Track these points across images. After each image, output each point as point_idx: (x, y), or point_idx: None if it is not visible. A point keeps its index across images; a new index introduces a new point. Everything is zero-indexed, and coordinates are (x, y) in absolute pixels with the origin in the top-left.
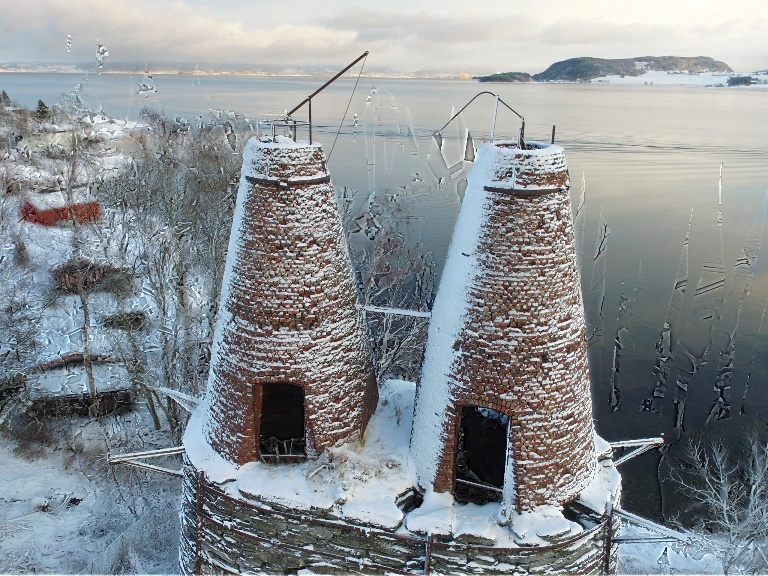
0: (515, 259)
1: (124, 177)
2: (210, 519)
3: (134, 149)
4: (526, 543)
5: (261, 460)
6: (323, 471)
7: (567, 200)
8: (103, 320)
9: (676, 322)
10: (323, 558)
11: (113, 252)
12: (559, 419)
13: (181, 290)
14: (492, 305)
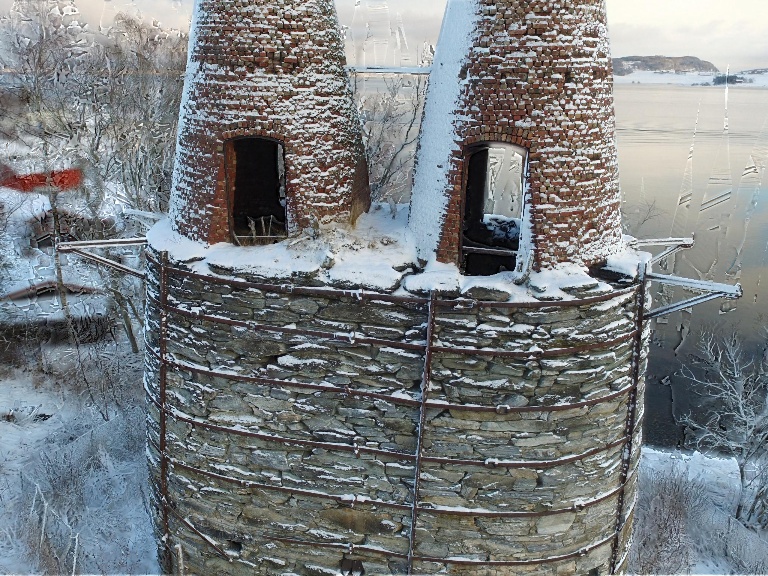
0: None
1: (95, 68)
2: (175, 309)
3: (107, 44)
4: (547, 296)
5: (235, 242)
6: (307, 240)
7: None
8: (72, 215)
9: None
10: (307, 338)
11: (84, 149)
12: (584, 156)
13: None
14: (506, 10)
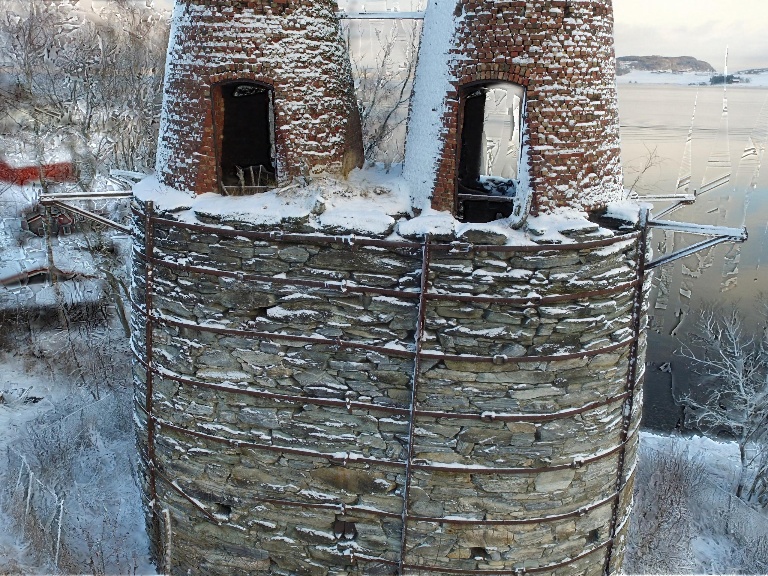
0: None
1: (87, 45)
2: (161, 261)
3: (99, 22)
4: (546, 240)
5: (223, 192)
6: (297, 188)
7: None
8: None
9: None
10: (297, 288)
11: (75, 128)
12: (584, 96)
13: None
14: None
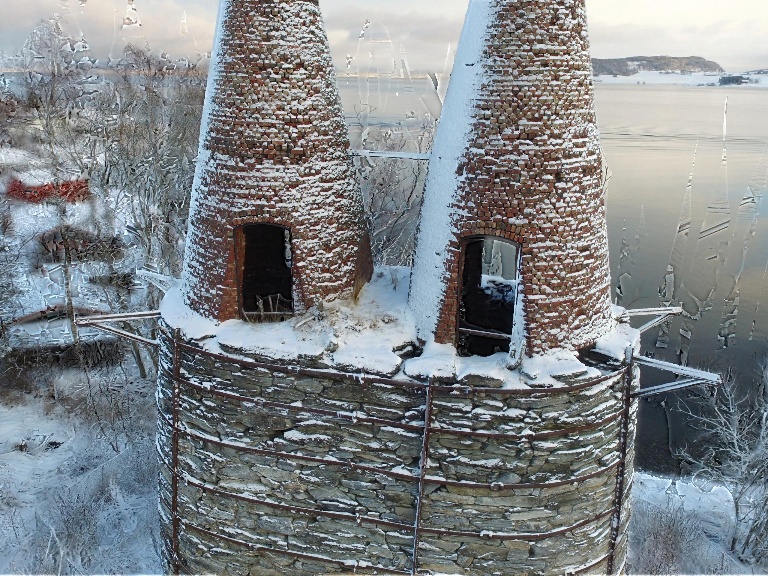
0: (526, 60)
1: (106, 105)
2: (188, 382)
3: (117, 79)
4: (538, 384)
5: (244, 318)
6: (312, 321)
7: (583, 0)
8: (83, 250)
9: (679, 267)
10: (312, 415)
11: (94, 183)
12: (574, 249)
13: (166, 226)
14: (500, 115)
